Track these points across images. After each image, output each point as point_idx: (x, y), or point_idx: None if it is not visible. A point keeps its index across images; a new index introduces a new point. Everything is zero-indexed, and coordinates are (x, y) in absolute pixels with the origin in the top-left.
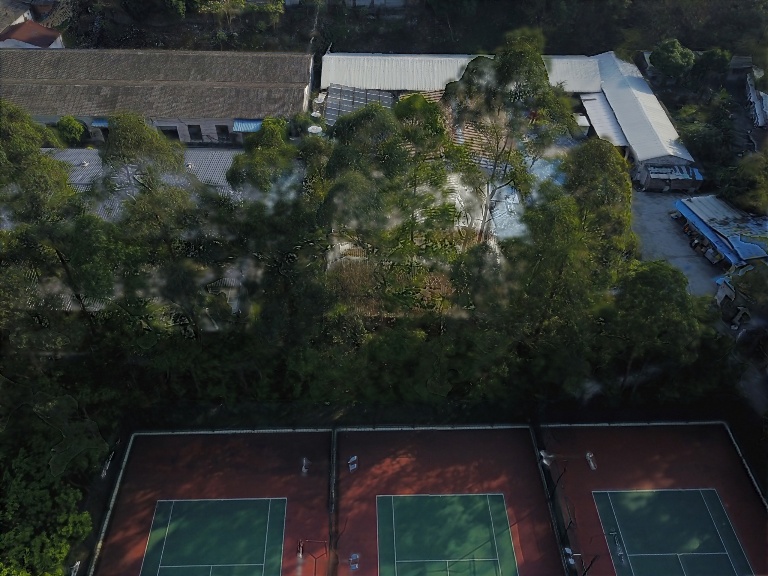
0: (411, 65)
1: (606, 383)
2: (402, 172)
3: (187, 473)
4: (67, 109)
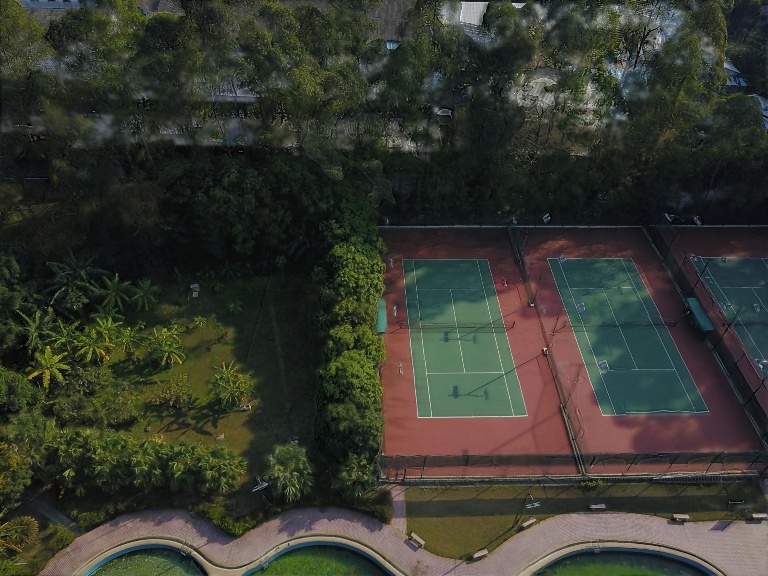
0: None
1: (696, 192)
2: (595, 18)
3: (416, 246)
4: None
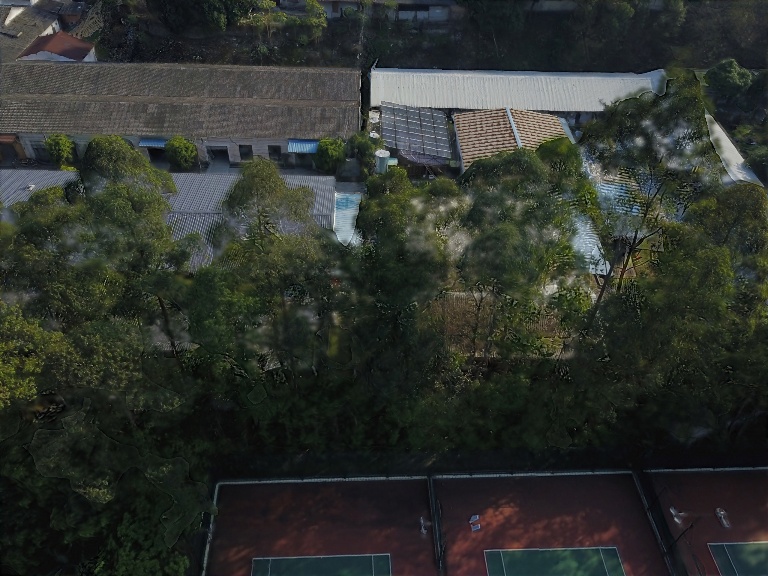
0: (462, 82)
1: None
2: (549, 220)
3: (280, 527)
4: (113, 128)
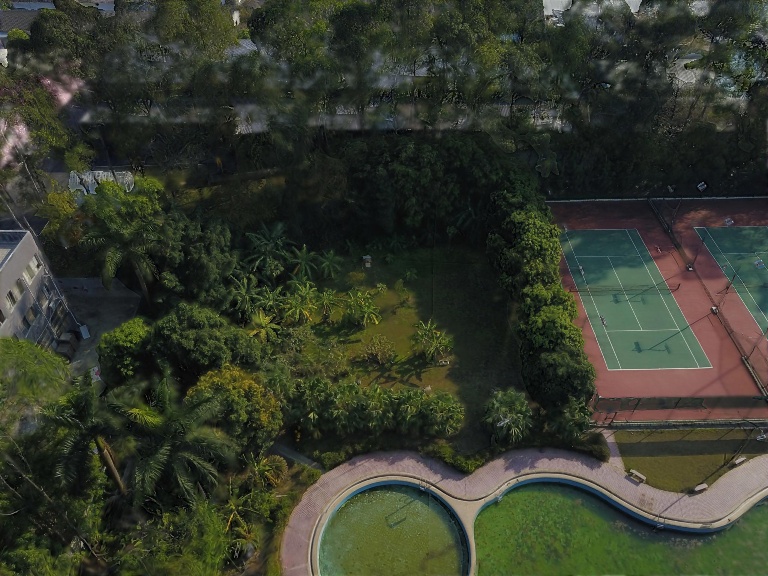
0: None
1: None
2: None
3: (564, 219)
4: None
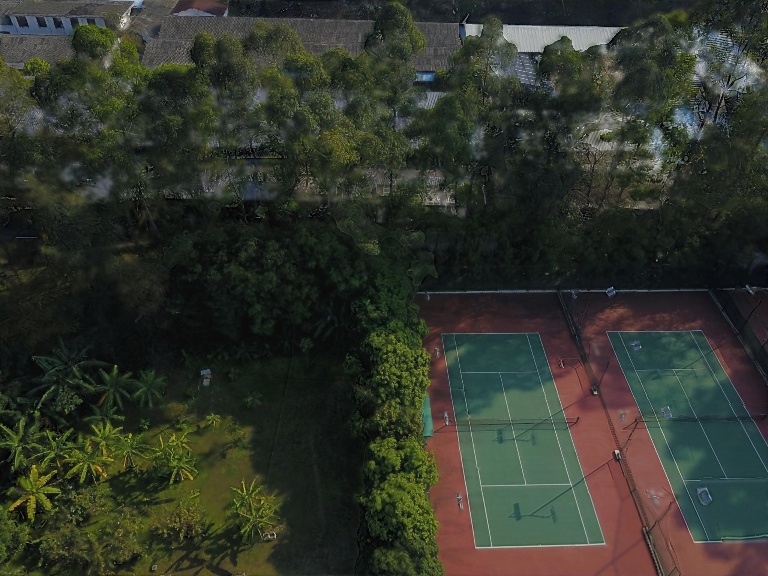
0: (541, 32)
1: None
2: (673, 66)
3: (456, 317)
4: None
